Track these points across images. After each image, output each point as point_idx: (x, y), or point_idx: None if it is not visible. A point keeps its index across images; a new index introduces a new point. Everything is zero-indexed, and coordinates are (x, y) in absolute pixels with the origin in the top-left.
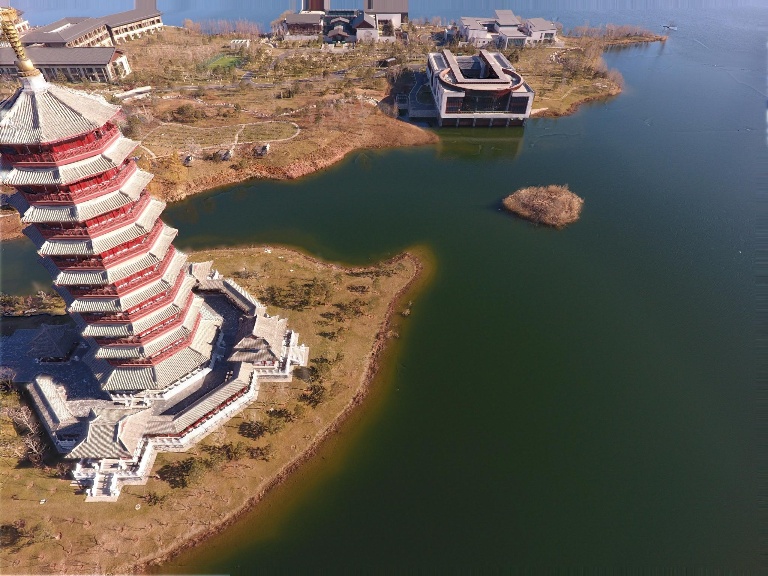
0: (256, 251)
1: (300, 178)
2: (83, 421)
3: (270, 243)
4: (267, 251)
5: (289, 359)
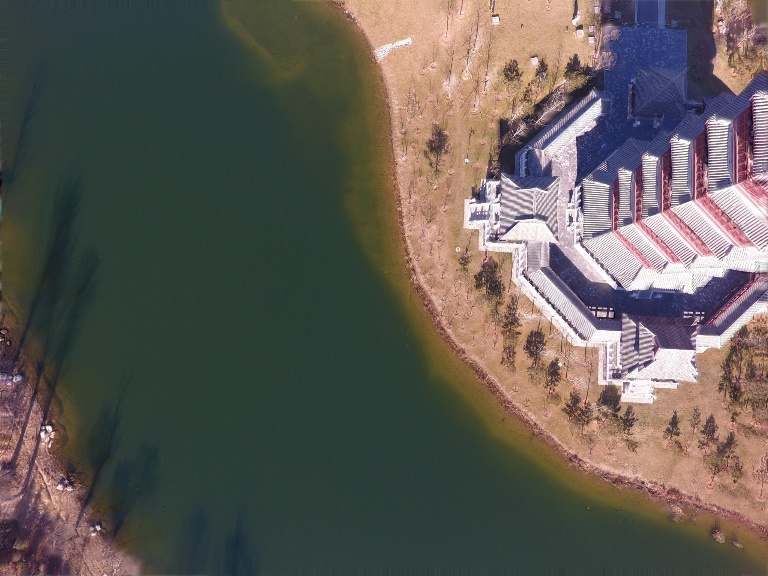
0: None
1: None
2: (544, 173)
3: None
4: None
5: (631, 382)
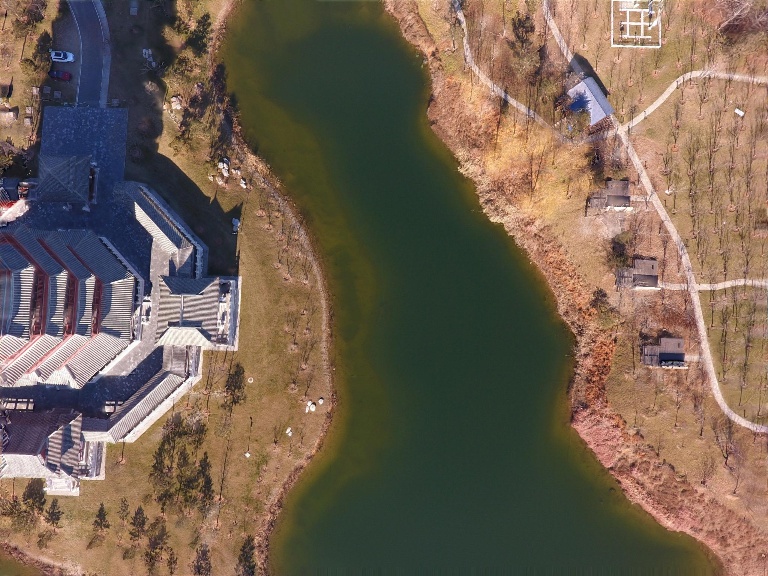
0: (312, 387)
1: (577, 436)
2: None
3: (348, 402)
4: (311, 405)
5: None
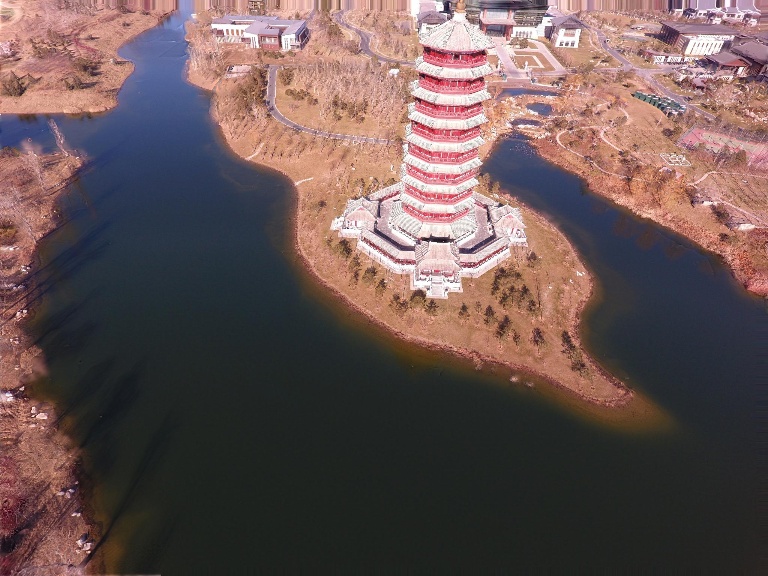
0: (576, 266)
1: (755, 295)
2: None
3: (599, 278)
4: (579, 273)
5: (429, 284)
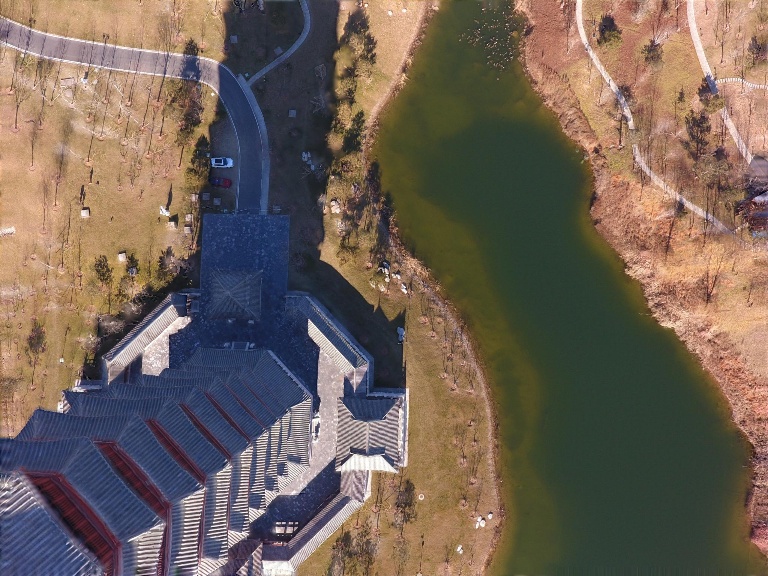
0: (481, 502)
1: (757, 551)
2: None
3: (516, 515)
4: (481, 521)
5: None
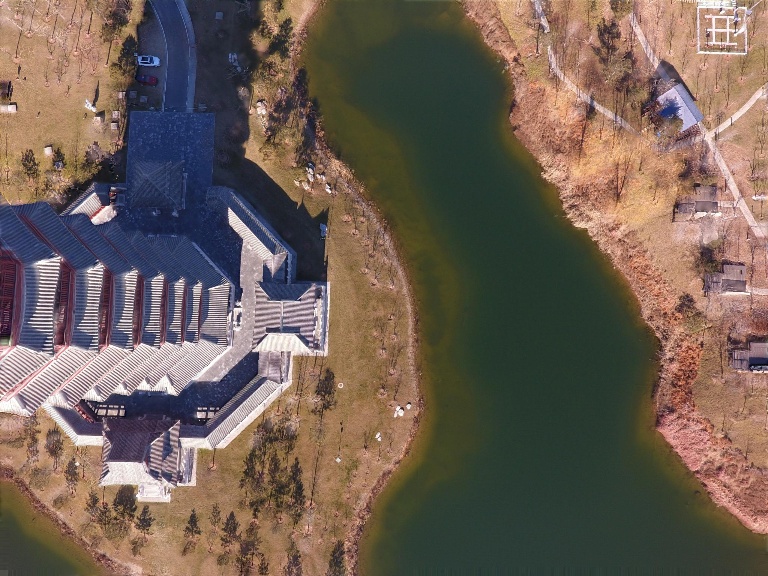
0: (400, 392)
1: (662, 439)
2: None
3: (435, 407)
4: (399, 410)
5: None
